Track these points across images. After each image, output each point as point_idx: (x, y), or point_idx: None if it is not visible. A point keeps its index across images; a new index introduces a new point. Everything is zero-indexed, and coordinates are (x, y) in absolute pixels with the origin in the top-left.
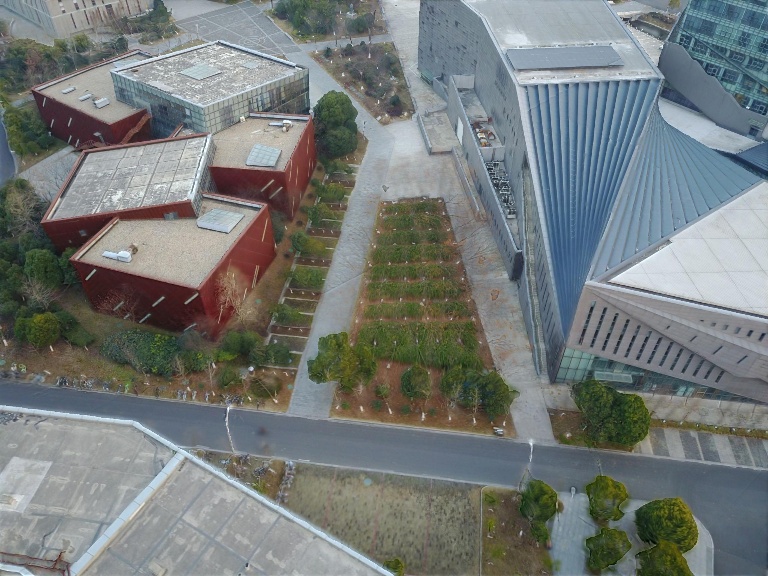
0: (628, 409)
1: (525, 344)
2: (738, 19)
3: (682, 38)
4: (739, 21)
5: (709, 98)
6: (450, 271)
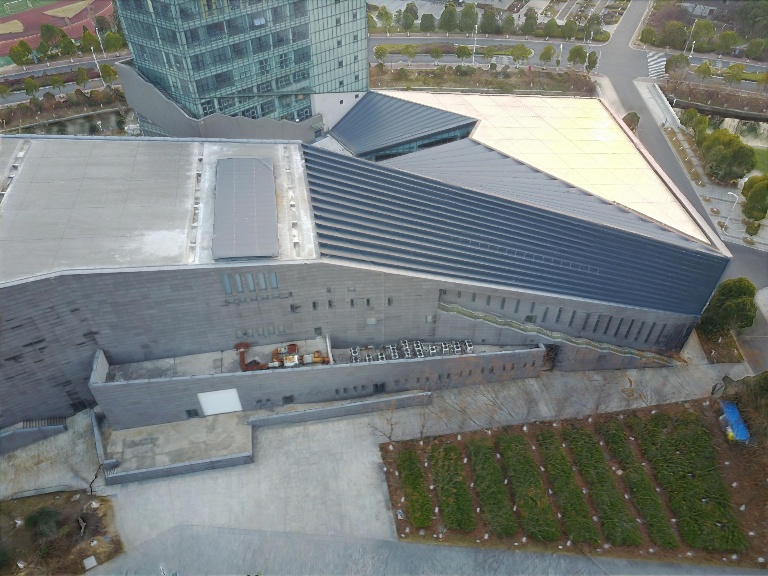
0: (753, 287)
1: (636, 373)
2: (249, 53)
3: (205, 107)
4: (251, 54)
5: (270, 138)
6: (551, 436)
